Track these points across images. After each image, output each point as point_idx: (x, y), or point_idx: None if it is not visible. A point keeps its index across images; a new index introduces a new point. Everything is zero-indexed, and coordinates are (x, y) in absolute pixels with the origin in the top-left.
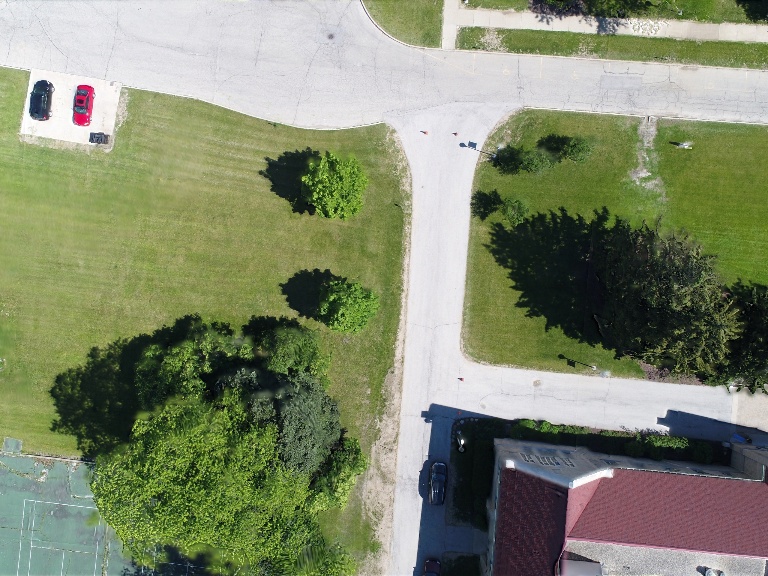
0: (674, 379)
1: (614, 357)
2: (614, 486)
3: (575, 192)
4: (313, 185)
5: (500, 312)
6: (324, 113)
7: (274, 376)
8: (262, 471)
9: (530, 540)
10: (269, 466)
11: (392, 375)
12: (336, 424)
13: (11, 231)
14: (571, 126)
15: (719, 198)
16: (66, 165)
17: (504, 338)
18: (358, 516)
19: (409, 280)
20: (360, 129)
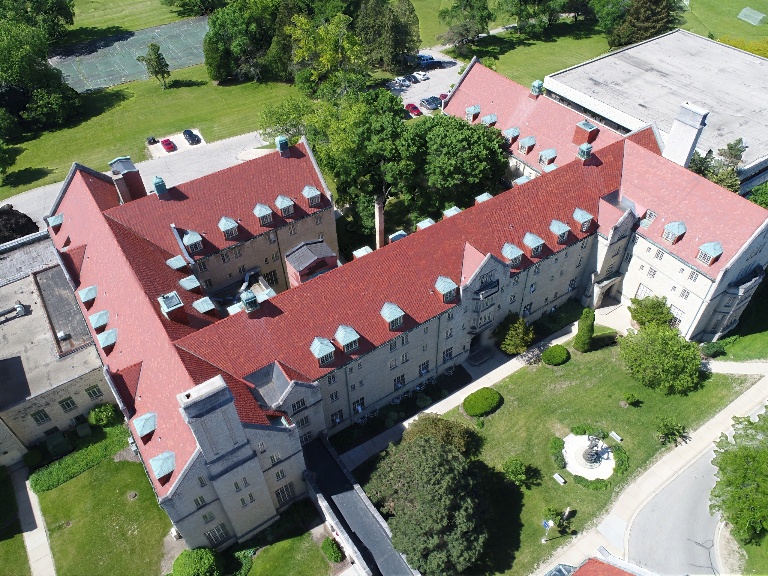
0: None
1: None
2: None
3: None
4: None
5: None
6: (27, 197)
7: None
8: None
9: None
10: None
11: None
12: None
13: None
14: None
15: None
16: None
17: None
18: None
19: None
20: (1, 201)
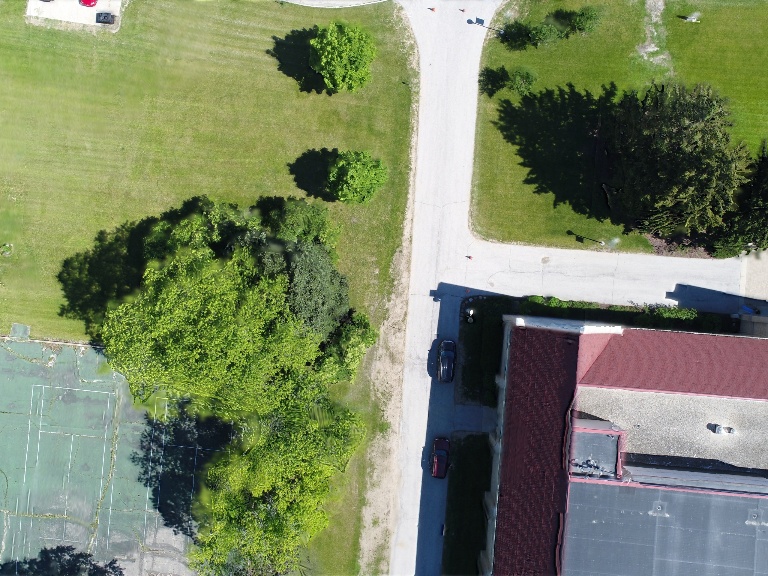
0: (682, 253)
1: (622, 232)
2: (624, 342)
3: (583, 68)
4: (321, 48)
5: (508, 189)
6: None
7: (283, 243)
8: (273, 321)
9: (541, 394)
10: (280, 317)
11: (400, 254)
12: (345, 297)
13: (18, 114)
14: (579, 1)
15: (727, 72)
16: (72, 46)
17: (512, 215)
18: (367, 397)
19: (417, 159)
20: (367, 6)
